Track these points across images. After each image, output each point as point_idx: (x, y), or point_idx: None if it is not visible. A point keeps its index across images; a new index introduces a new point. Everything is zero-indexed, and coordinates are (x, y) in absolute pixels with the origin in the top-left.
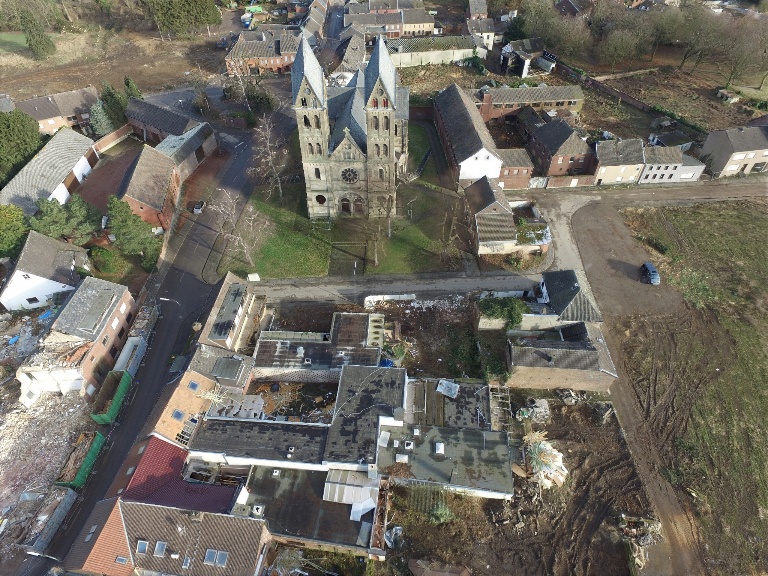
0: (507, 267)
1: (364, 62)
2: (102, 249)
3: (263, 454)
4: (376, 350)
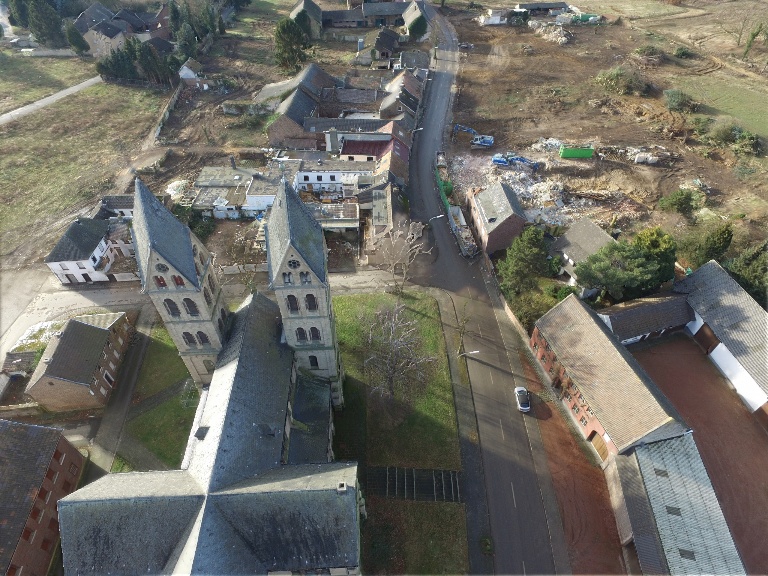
0: (107, 312)
1: None
2: (569, 291)
3: (334, 162)
4: None
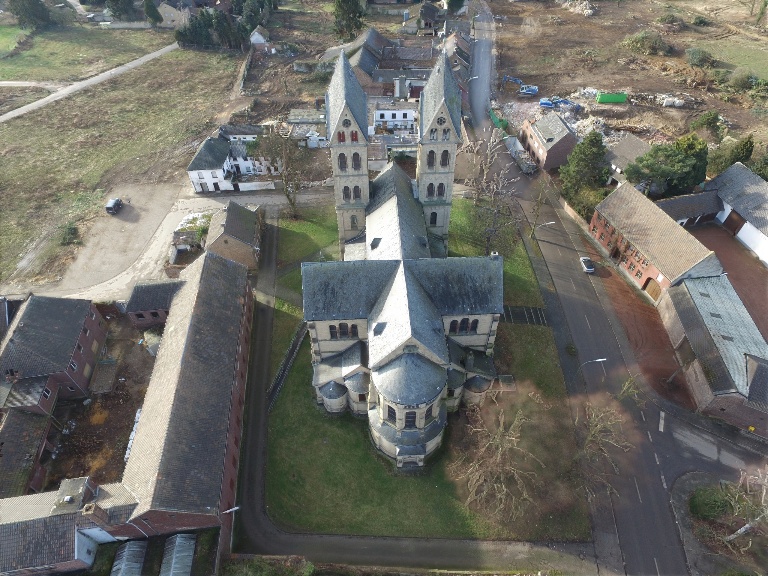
0: None
1: None
2: None
3: (405, 103)
4: None
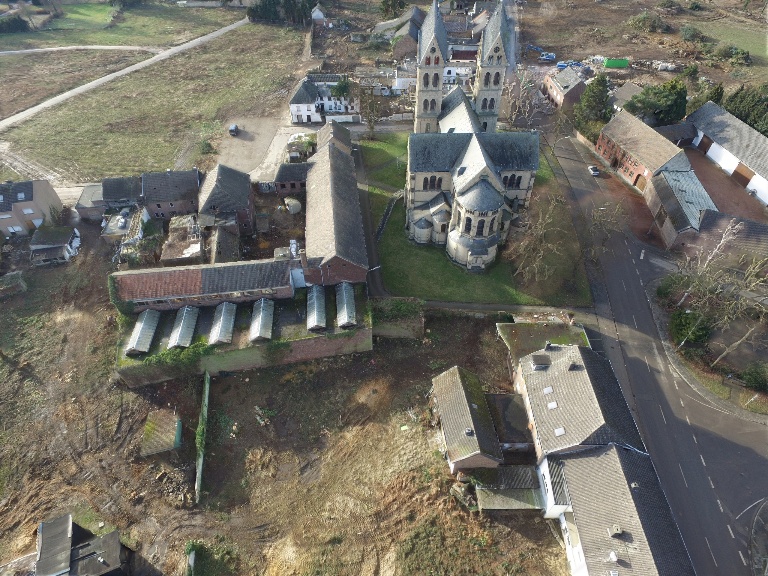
0: None
1: (582, 573)
2: None
3: None
4: (412, 90)
